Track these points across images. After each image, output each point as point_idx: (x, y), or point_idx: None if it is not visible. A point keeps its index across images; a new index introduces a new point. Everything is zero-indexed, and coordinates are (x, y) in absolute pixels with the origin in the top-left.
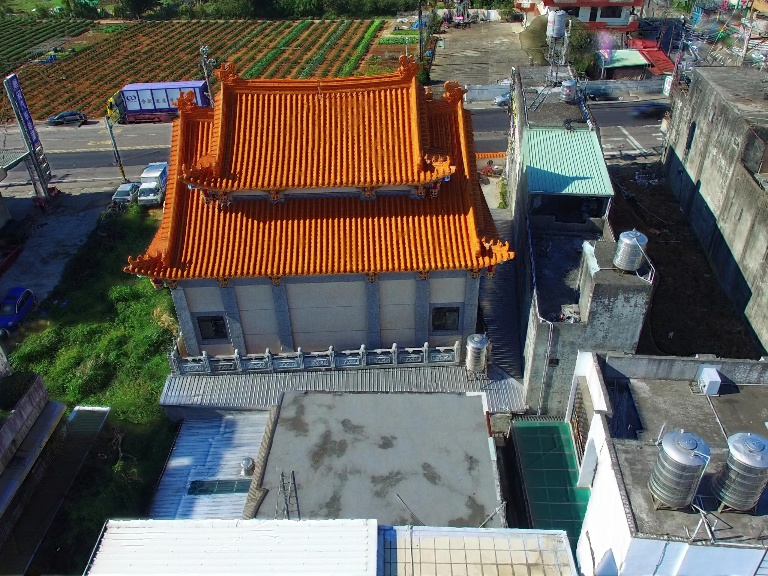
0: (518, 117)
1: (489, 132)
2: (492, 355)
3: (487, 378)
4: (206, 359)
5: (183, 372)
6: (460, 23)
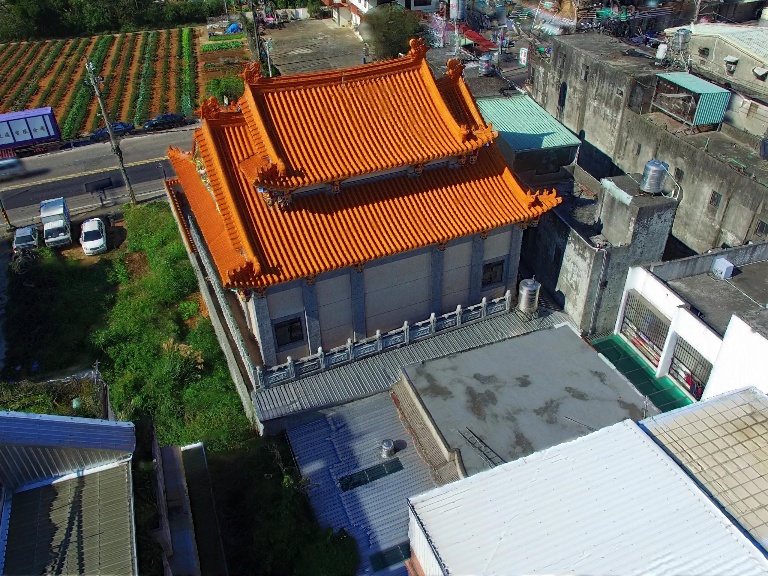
0: None
1: None
2: None
3: (537, 317)
4: (292, 364)
5: (267, 385)
6: (275, 24)
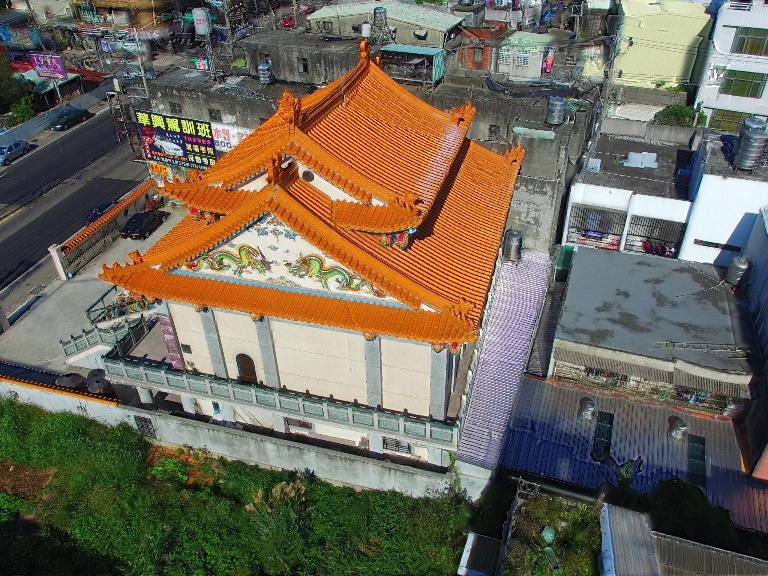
0: (232, 117)
1: (59, 186)
2: None
3: (517, 261)
4: None
5: None
6: None
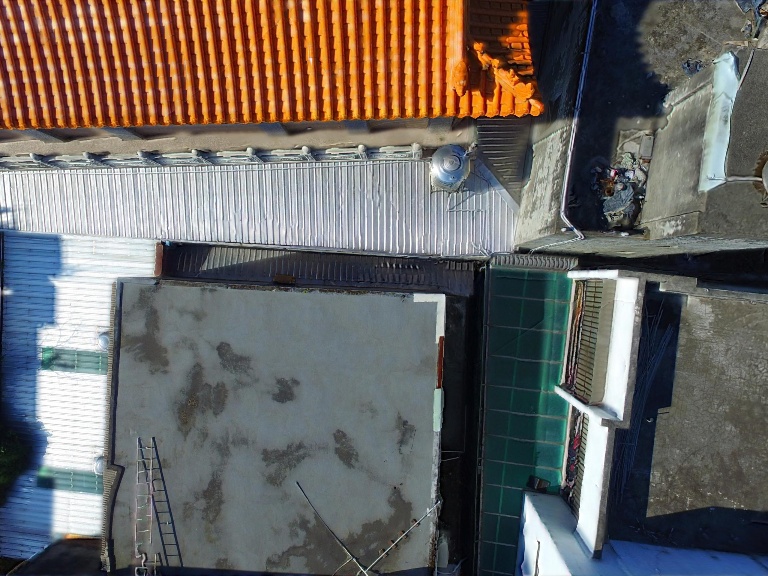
0: None
1: None
2: (480, 133)
3: None
4: None
5: None
6: None
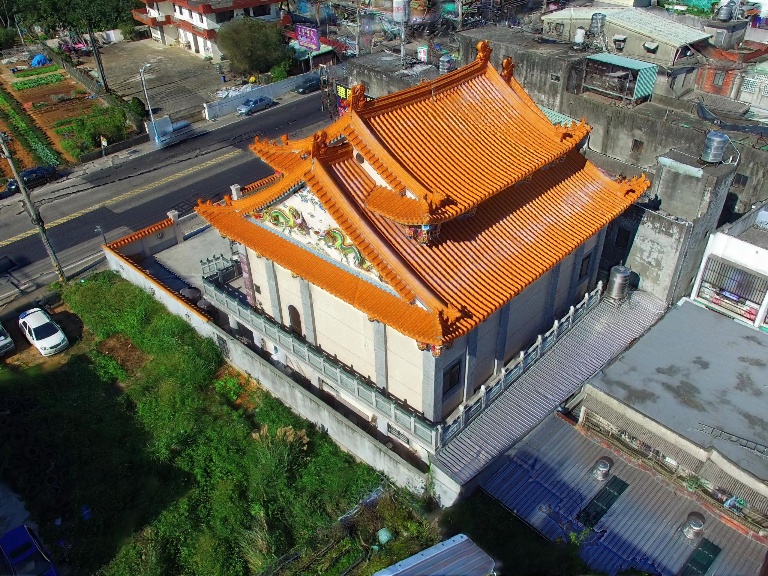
0: None
1: (276, 139)
2: None
3: (624, 300)
4: (464, 413)
5: (444, 443)
6: (90, 50)
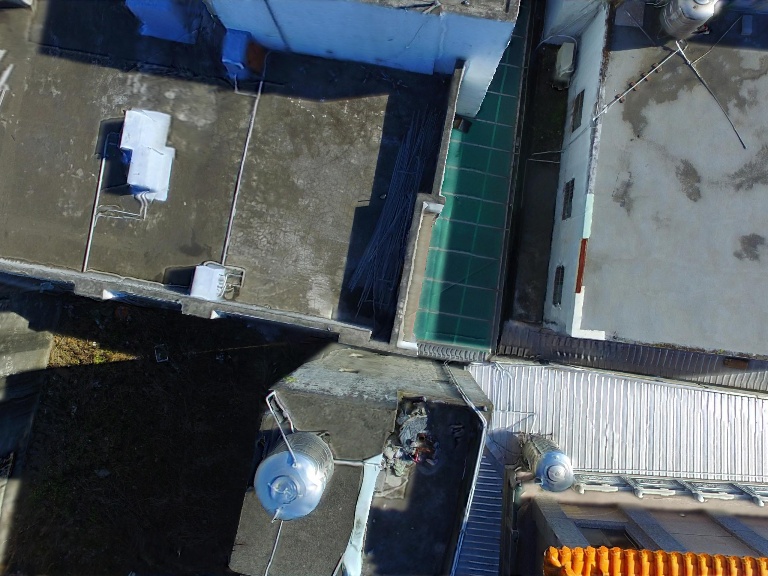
0: None
1: None
2: (499, 491)
3: None
4: None
5: None
6: None
